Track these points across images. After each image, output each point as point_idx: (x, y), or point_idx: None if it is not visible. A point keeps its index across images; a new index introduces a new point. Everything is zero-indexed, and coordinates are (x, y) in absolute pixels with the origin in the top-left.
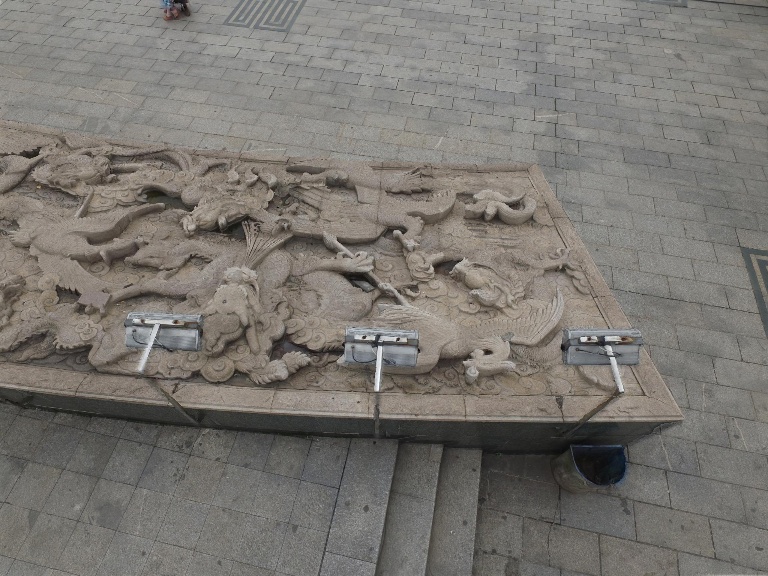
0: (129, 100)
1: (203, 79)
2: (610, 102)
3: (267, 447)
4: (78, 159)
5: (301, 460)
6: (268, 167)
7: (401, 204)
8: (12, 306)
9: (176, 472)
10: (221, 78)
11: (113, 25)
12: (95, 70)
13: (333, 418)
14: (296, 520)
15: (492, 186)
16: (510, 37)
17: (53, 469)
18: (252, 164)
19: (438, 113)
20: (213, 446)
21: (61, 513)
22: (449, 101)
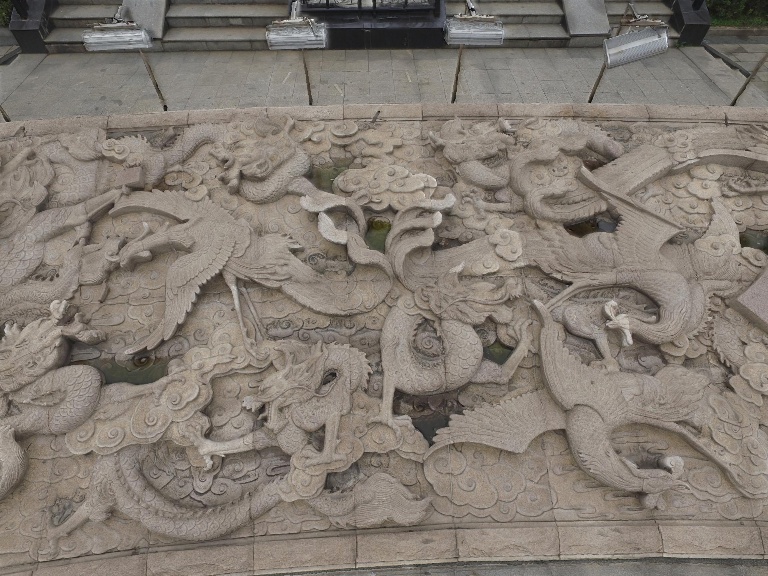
0: None
1: None
2: None
3: None
4: (316, 411)
5: None
6: None
7: None
8: None
9: None
10: None
11: None
12: None
13: None
14: None
15: None
16: None
17: None
18: (2, 551)
19: None
20: None
21: None
22: None
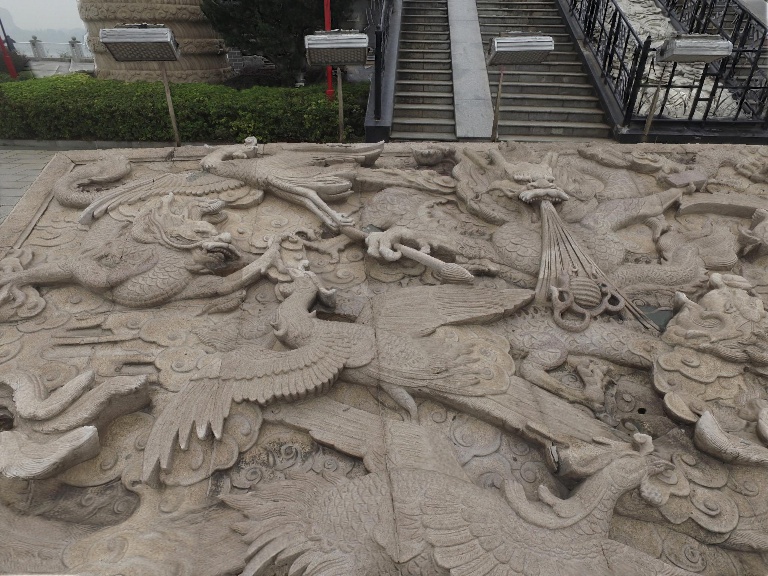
0: None
1: None
2: None
3: None
4: None
5: None
6: None
7: (320, 373)
8: (766, 184)
9: None
10: None
11: None
12: None
13: None
14: None
15: None
16: None
17: None
18: None
19: None
20: None
21: None
22: None
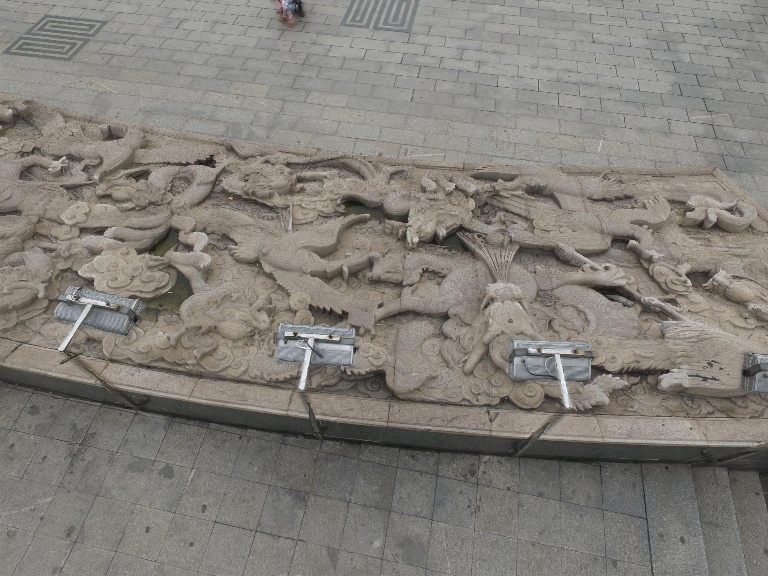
0: (267, 105)
1: (337, 82)
2: (760, 102)
3: (556, 474)
4: (263, 168)
5: (596, 488)
6: (458, 174)
7: (619, 212)
8: None
9: (469, 503)
10: (355, 81)
11: (228, 27)
12: (223, 74)
13: (667, 446)
14: (613, 554)
15: (692, 191)
16: (638, 36)
17: (338, 502)
18: None
19: (589, 115)
20: (499, 474)
21: (361, 550)
22: (597, 102)
